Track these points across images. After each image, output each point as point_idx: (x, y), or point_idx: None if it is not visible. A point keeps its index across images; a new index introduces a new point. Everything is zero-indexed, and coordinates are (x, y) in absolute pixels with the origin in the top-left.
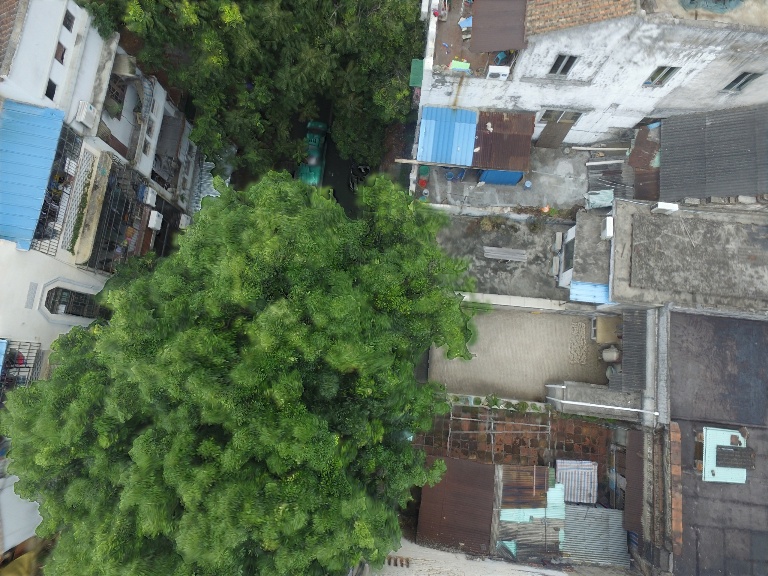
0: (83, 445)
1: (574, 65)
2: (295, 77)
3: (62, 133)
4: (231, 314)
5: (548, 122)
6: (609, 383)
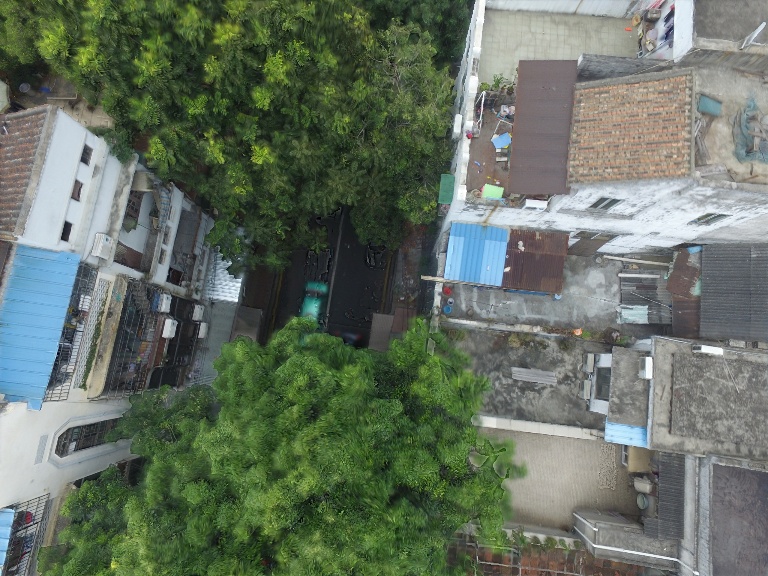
0: None
1: (617, 205)
2: (320, 198)
3: (77, 272)
4: None
5: (581, 238)
6: (644, 529)
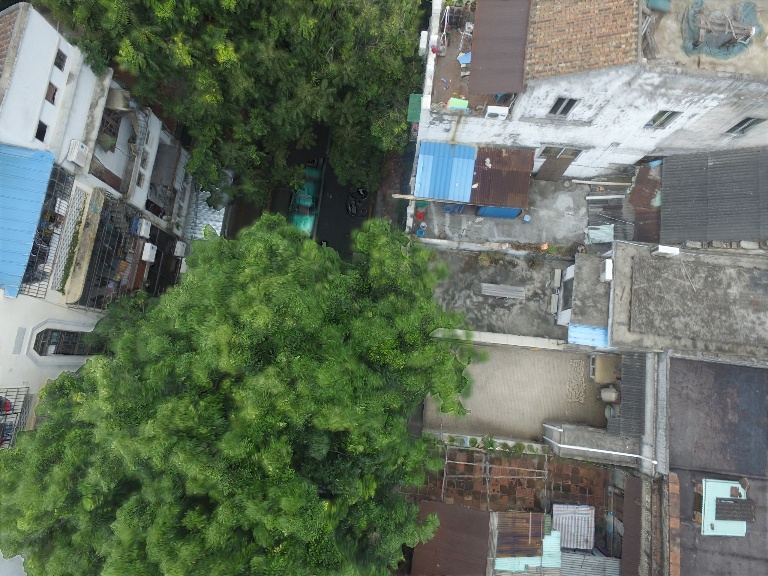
0: (67, 506)
1: (574, 107)
2: (291, 113)
3: (53, 174)
4: (219, 375)
5: (548, 157)
6: (607, 427)
